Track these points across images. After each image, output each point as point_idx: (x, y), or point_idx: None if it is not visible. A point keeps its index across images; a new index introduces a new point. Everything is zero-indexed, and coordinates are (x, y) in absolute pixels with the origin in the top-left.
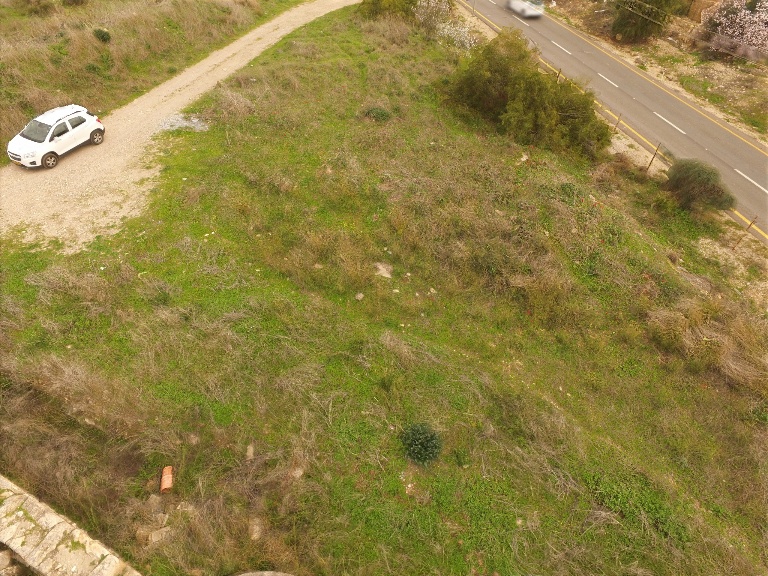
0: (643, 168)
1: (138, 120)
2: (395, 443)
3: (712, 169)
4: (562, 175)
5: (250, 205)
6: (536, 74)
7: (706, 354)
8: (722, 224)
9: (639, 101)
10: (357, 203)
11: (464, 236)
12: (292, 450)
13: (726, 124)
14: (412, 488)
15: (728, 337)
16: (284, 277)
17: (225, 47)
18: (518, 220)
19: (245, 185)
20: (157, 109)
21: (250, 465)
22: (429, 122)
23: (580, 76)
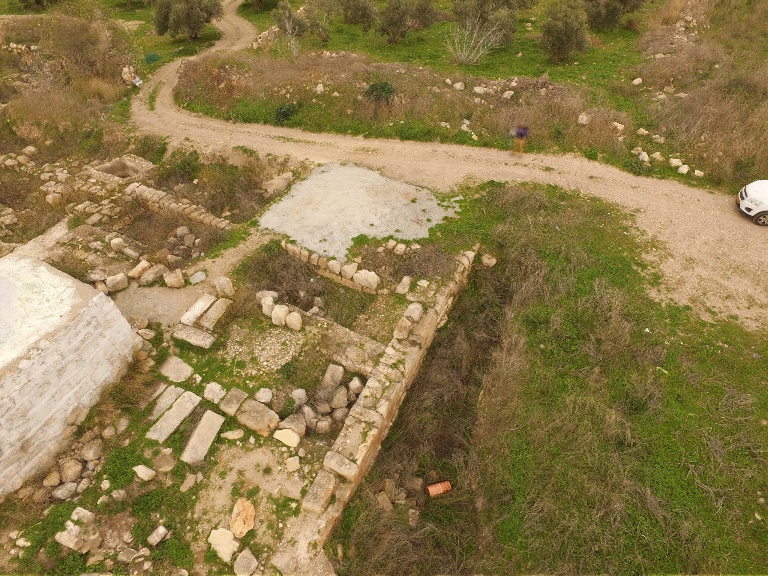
0: None
1: None
2: None
3: None
4: None
5: None
6: None
7: None
8: None
9: None
10: None
11: None
12: None
13: None
14: None
15: None
16: None
17: None
18: None
19: None
20: None
21: None
22: None
23: None
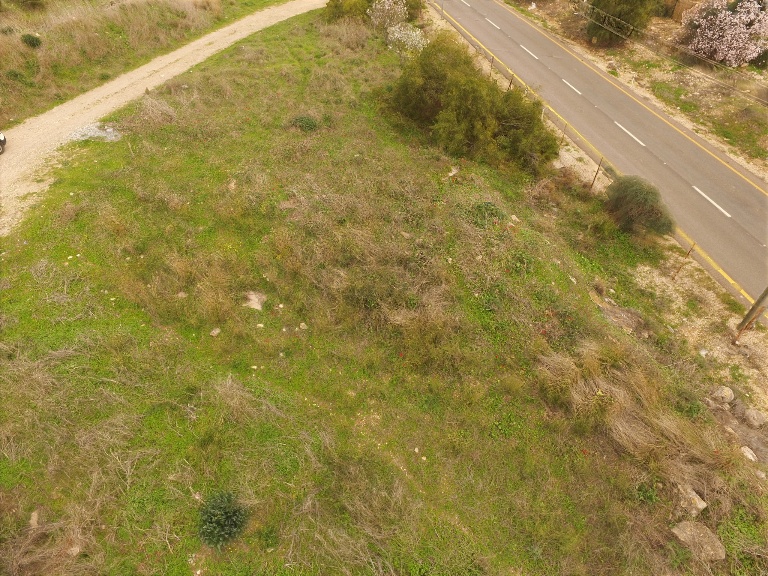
0: (586, 184)
1: (50, 129)
2: (193, 517)
3: (651, 188)
4: (488, 192)
5: (130, 224)
6: (471, 81)
7: (593, 413)
8: (665, 249)
9: (601, 109)
10: (247, 223)
11: (353, 262)
12: (70, 522)
13: (694, 135)
14: (201, 575)
15: (624, 392)
16: (139, 307)
17: (171, 52)
18: (421, 244)
19: (132, 201)
20: (75, 117)
21: (30, 536)
22: (360, 132)
23: (542, 82)
